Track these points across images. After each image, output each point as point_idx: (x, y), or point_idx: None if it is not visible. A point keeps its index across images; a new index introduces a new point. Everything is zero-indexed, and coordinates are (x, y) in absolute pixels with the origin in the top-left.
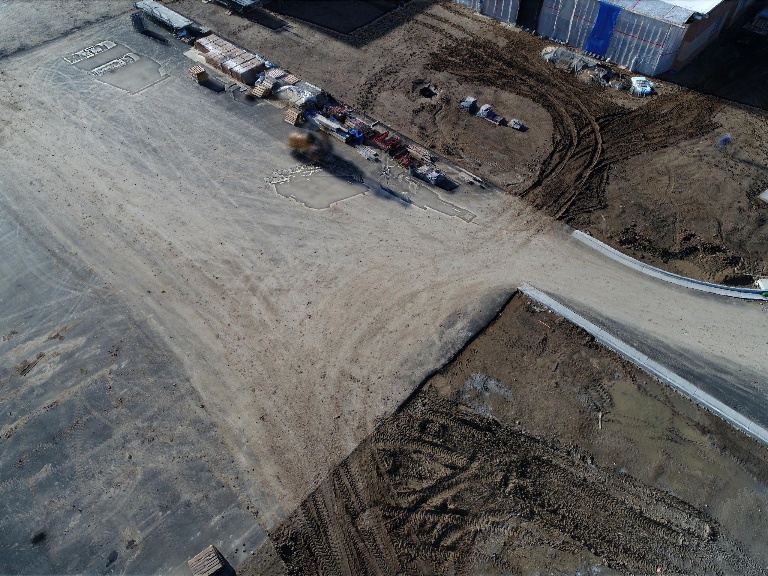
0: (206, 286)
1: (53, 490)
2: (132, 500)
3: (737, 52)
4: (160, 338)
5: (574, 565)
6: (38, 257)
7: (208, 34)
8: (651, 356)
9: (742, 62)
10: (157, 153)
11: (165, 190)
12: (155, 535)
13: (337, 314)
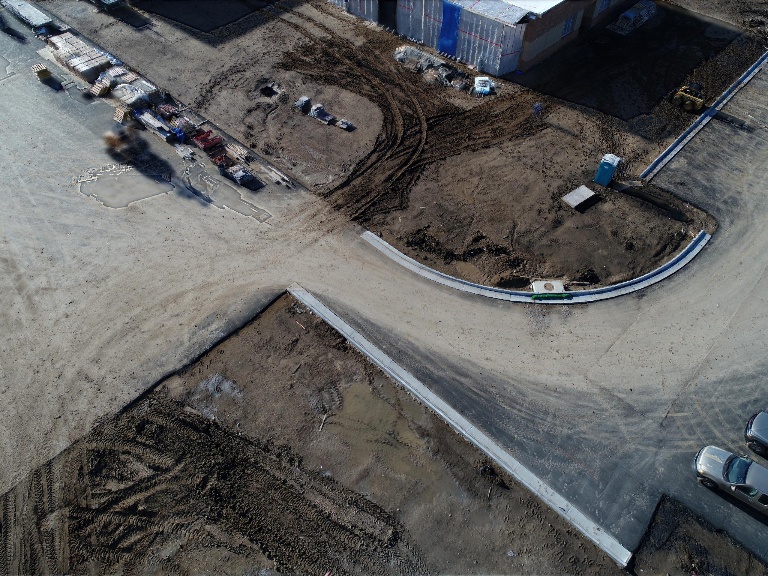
0: None
1: None
2: None
3: (591, 52)
4: None
5: (243, 568)
6: None
7: None
8: (396, 358)
9: (592, 62)
10: None
11: None
12: None
13: (95, 314)
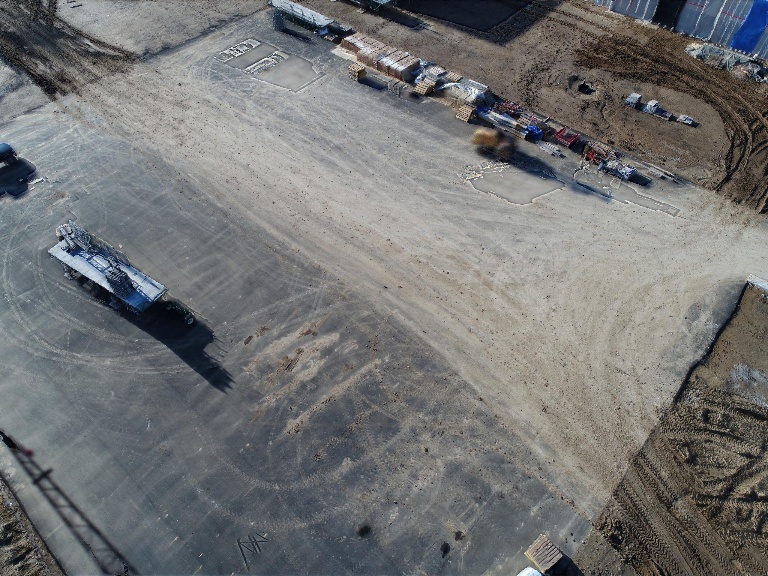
0: (440, 281)
1: (361, 483)
2: (444, 492)
3: None
4: (413, 333)
5: None
6: (261, 254)
7: (349, 32)
8: None
9: None
10: (342, 150)
11: (364, 187)
12: (480, 526)
13: (580, 307)
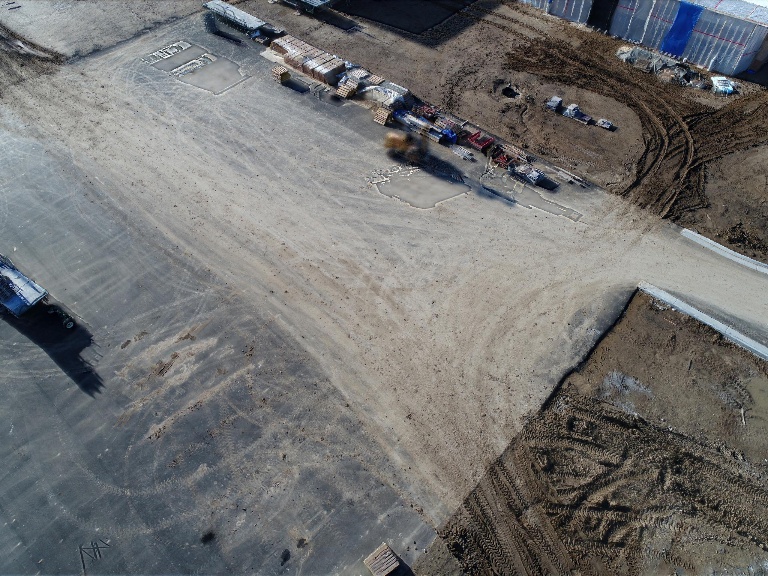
0: (328, 286)
1: (213, 490)
2: (294, 499)
3: None
4: (292, 338)
5: (745, 560)
6: (154, 258)
7: (281, 34)
8: None
9: None
10: (253, 153)
11: (268, 190)
12: (324, 534)
13: (463, 313)
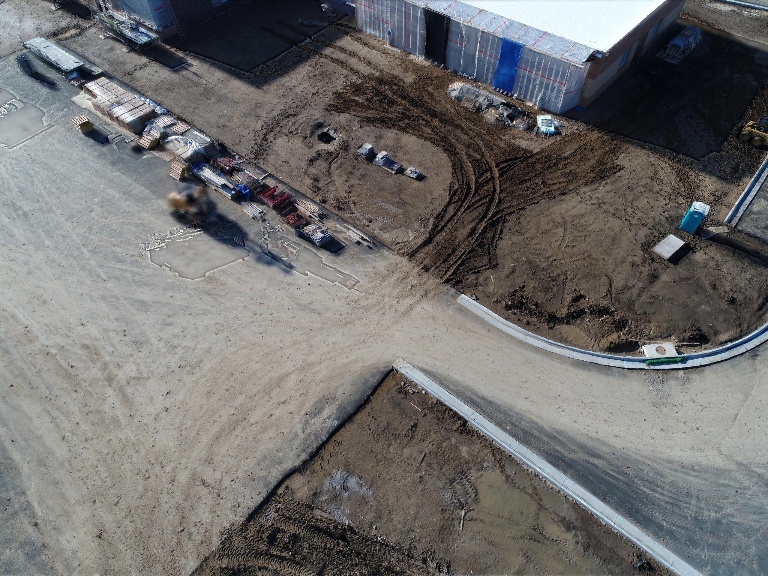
0: (59, 377)
1: None
2: None
3: (647, 84)
4: (0, 442)
5: None
6: None
7: (100, 75)
8: (523, 441)
9: (651, 95)
10: (27, 218)
11: (30, 262)
12: None
13: (196, 405)
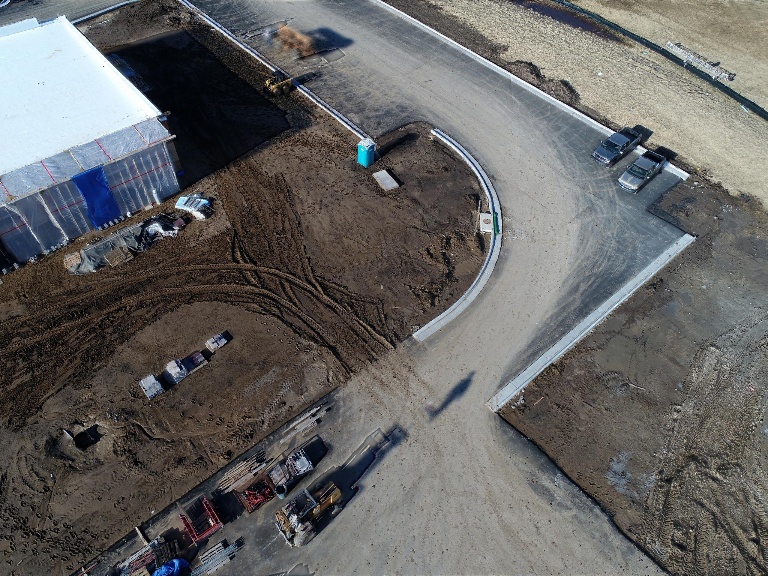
0: None
1: None
2: None
3: (170, 117)
4: None
5: None
6: None
7: None
8: (568, 329)
9: (190, 121)
10: None
11: None
12: None
13: None
